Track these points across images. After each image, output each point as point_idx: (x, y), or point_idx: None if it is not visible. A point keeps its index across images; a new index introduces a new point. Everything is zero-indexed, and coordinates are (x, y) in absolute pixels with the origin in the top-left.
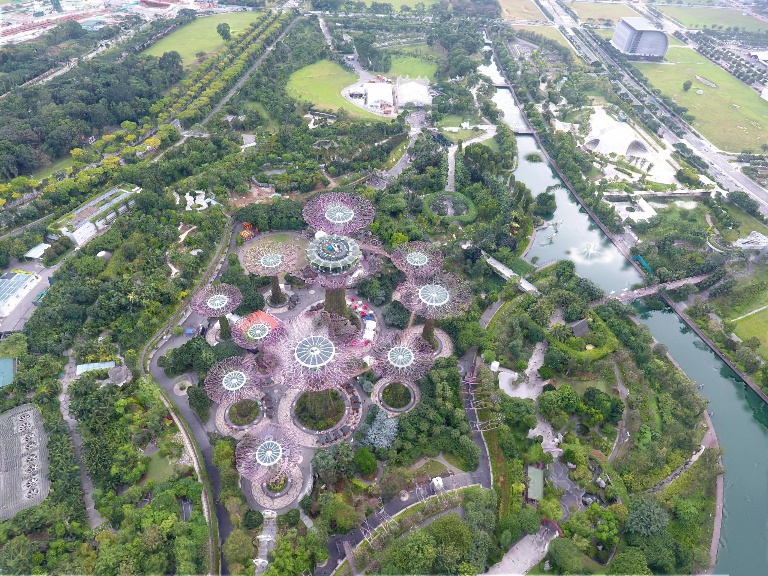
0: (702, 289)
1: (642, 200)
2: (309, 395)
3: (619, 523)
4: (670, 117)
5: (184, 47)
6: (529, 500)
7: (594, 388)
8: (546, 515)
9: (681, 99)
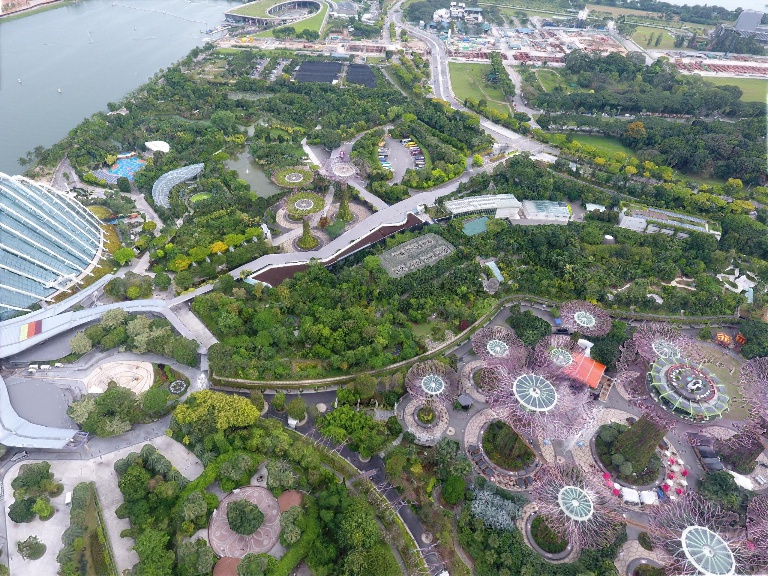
0: None
1: None
2: None
3: None
4: None
5: None
6: None
7: None
8: None
9: None
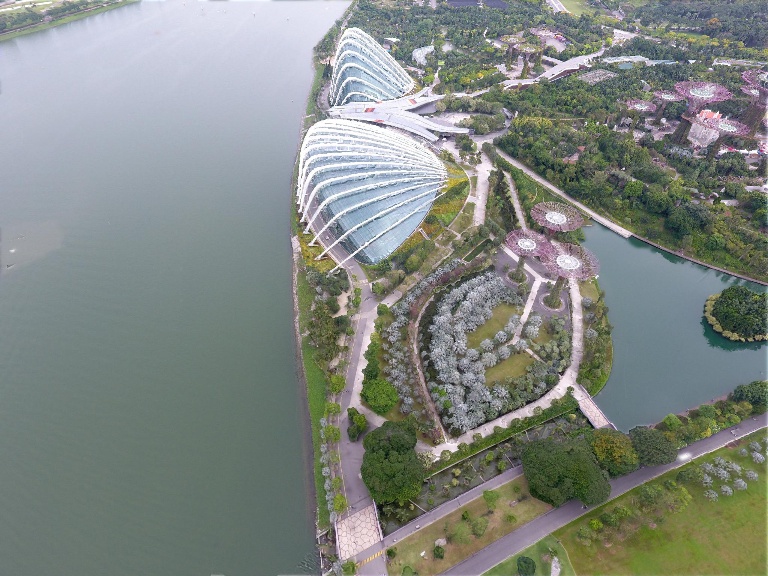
0: None
1: None
2: None
3: None
4: None
5: None
6: None
7: None
8: None
9: None
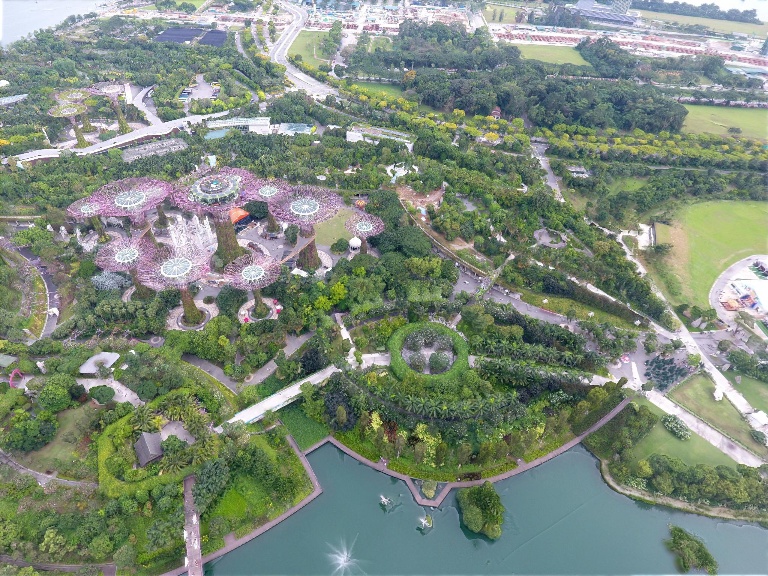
0: None
1: None
2: None
3: None
4: None
5: (764, 124)
6: None
7: (49, 425)
8: None
9: None
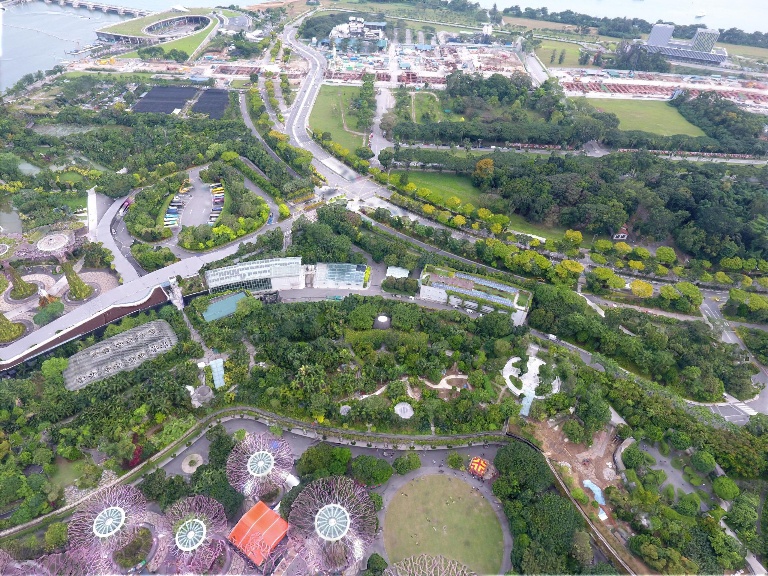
0: None
1: None
2: None
3: None
4: None
5: None
6: None
7: None
8: None
9: None
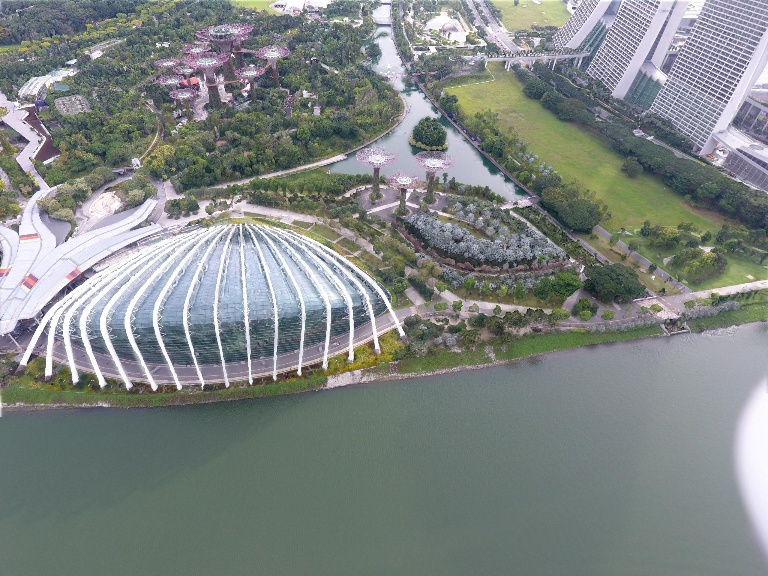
0: (437, 77)
1: (434, 49)
2: (209, 93)
3: (330, 120)
4: (491, 17)
5: None
6: (298, 120)
7: None
8: (300, 118)
9: (508, 9)
